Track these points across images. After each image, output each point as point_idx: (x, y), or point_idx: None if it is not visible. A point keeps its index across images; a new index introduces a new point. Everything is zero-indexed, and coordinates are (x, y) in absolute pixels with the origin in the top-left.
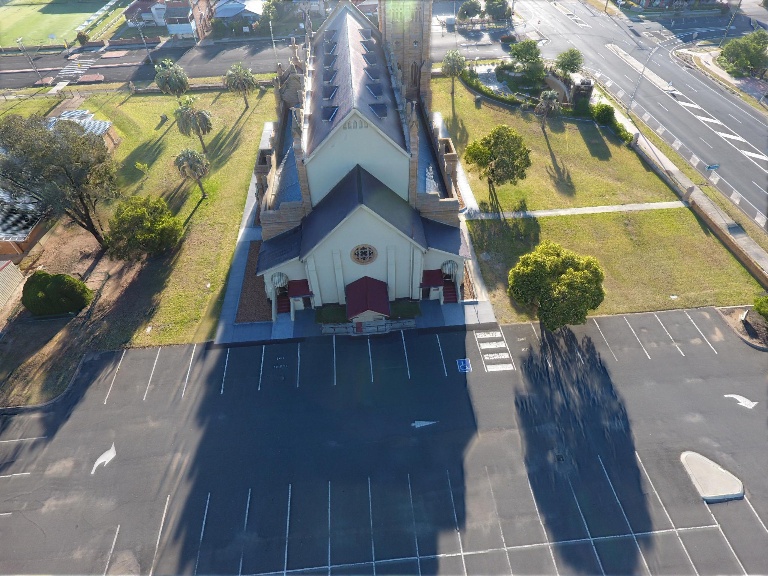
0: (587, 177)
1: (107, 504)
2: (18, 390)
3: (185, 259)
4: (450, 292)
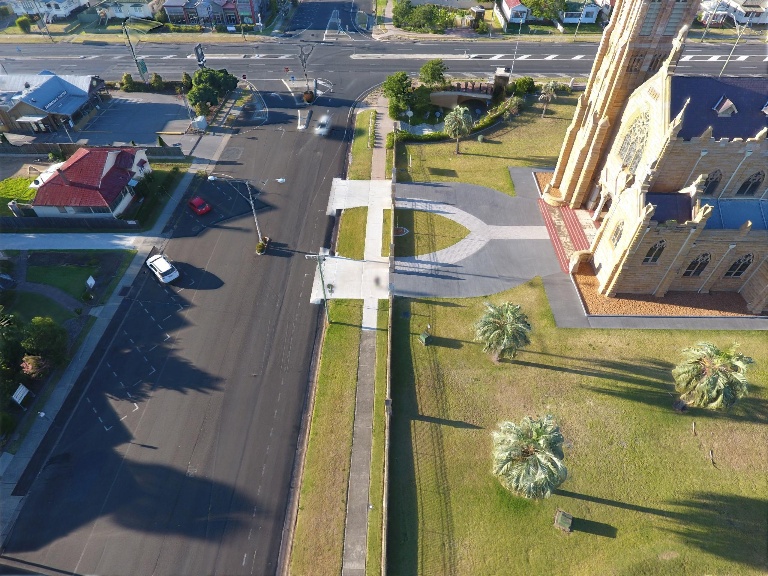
0: None
1: None
2: None
3: None
4: None
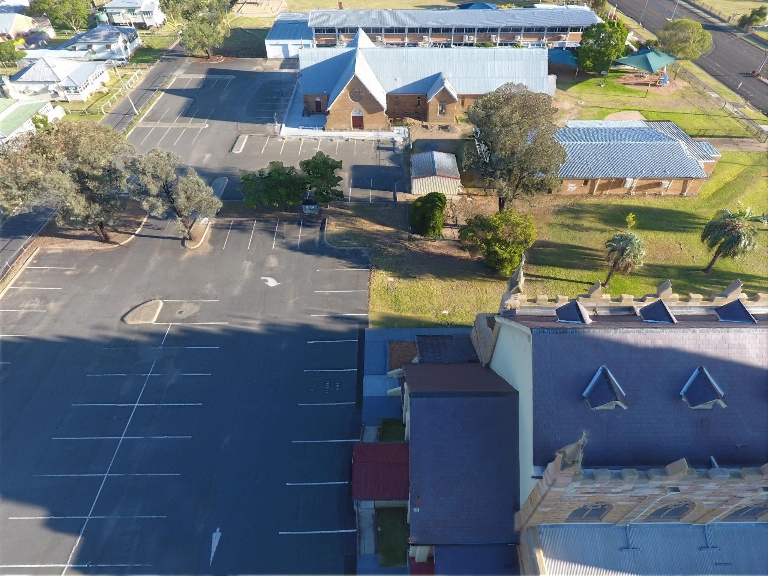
0: None
1: (236, 291)
2: (340, 224)
3: (486, 287)
4: None
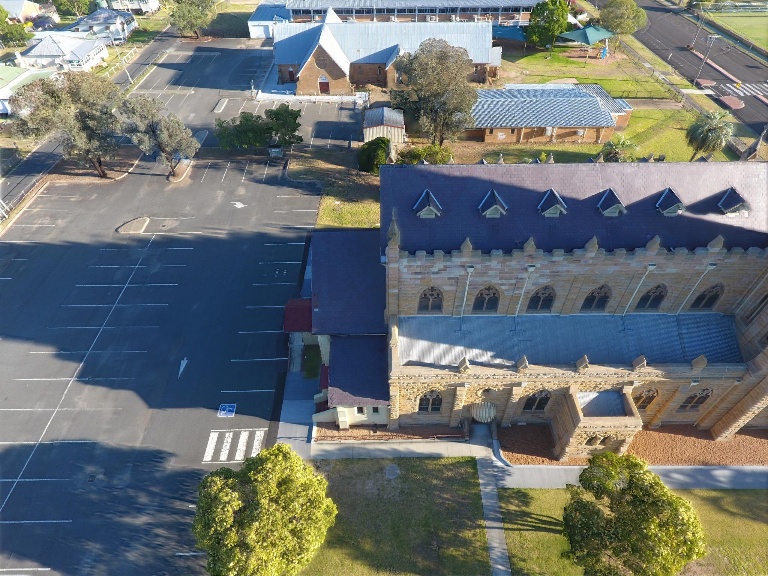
0: None
1: (209, 211)
2: (300, 164)
3: None
4: (327, 409)
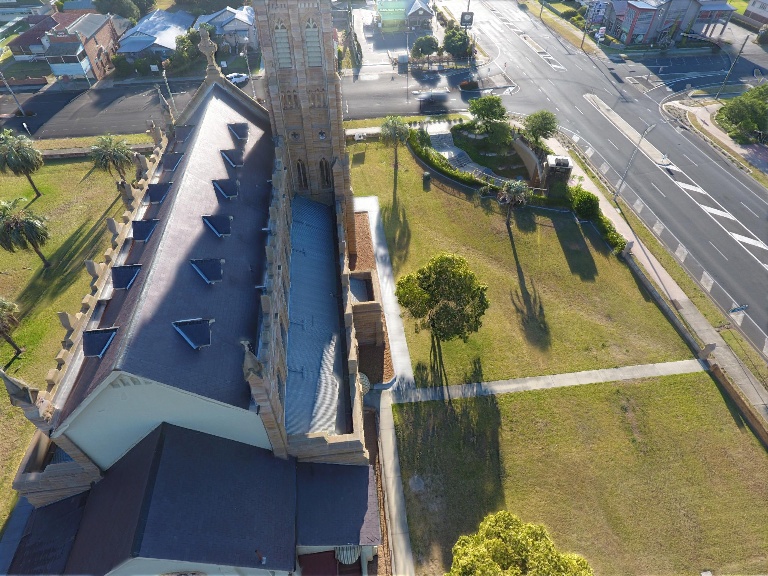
0: (566, 312)
1: None
2: None
3: None
4: None
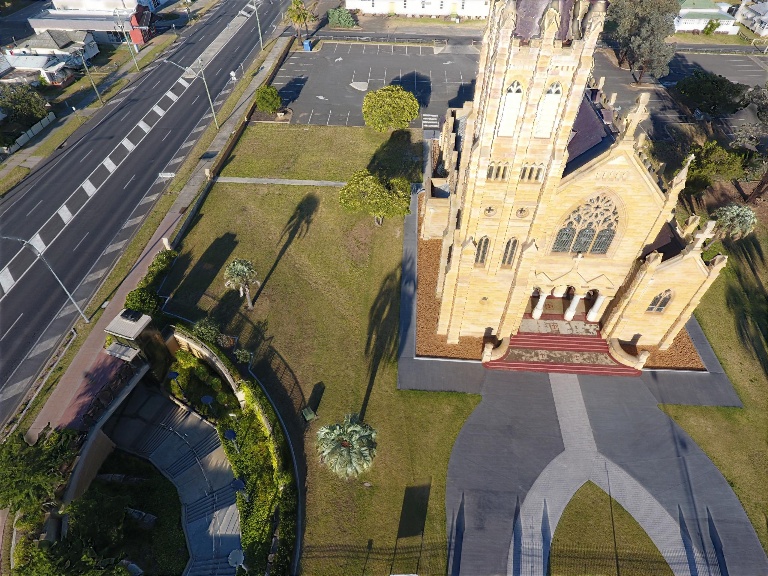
0: (272, 217)
1: None
2: None
3: None
4: None
